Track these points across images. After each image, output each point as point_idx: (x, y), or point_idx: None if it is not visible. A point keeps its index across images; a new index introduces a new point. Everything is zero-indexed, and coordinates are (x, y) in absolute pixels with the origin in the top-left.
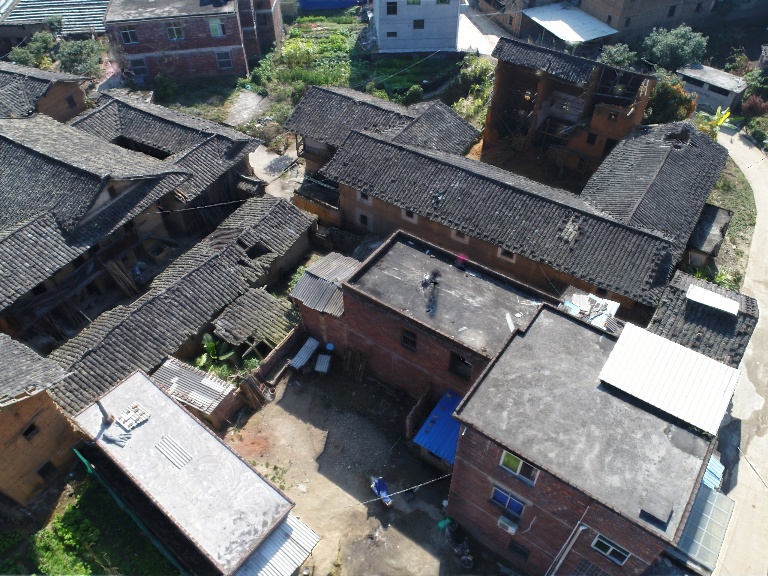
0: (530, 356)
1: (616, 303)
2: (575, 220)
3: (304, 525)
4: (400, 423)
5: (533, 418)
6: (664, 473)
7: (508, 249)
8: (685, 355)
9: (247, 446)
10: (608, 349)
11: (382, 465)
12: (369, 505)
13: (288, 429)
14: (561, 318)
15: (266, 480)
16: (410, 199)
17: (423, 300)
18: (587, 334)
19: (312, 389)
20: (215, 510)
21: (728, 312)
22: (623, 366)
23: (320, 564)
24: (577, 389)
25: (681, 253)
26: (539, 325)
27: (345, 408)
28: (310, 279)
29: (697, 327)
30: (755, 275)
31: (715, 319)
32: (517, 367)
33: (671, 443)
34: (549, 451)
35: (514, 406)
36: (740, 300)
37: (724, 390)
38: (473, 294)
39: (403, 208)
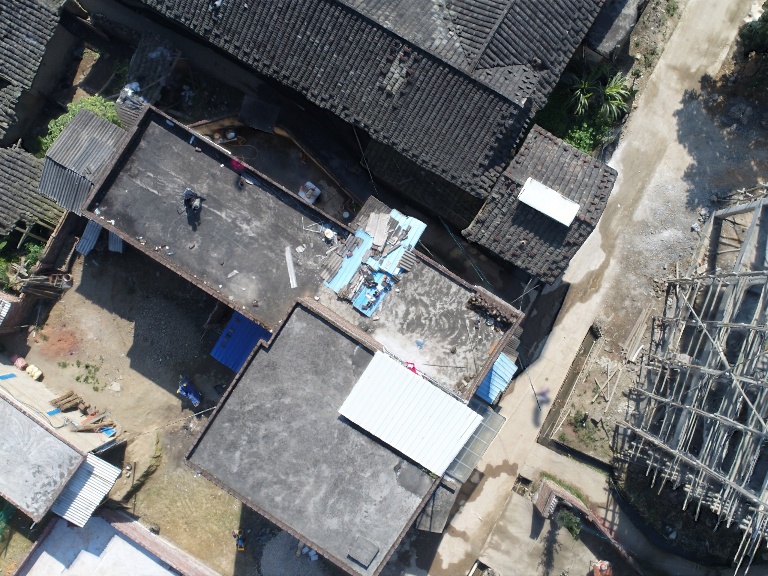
0: (272, 379)
1: (422, 225)
2: (403, 59)
3: (104, 462)
4: (209, 308)
5: (265, 458)
6: (381, 514)
7: (314, 101)
8: (431, 395)
9: (54, 345)
10: (361, 365)
11: (193, 356)
12: (183, 398)
13: (93, 321)
14: (316, 321)
15: (54, 435)
16: (178, 1)
17: (186, 229)
18: (341, 344)
19: (112, 270)
20: (13, 465)
21: (560, 222)
22: (365, 402)
23: (140, 459)
24: (316, 421)
25: (549, 92)
26: (288, 333)
27: (150, 292)
28: (56, 169)
29: (524, 232)
30: (674, 55)
31: (547, 223)
32: (256, 394)
33: (397, 482)
34: (276, 495)
35: (247, 445)
36: (592, 184)
37: (461, 435)
38: (248, 216)
39: (170, 17)
